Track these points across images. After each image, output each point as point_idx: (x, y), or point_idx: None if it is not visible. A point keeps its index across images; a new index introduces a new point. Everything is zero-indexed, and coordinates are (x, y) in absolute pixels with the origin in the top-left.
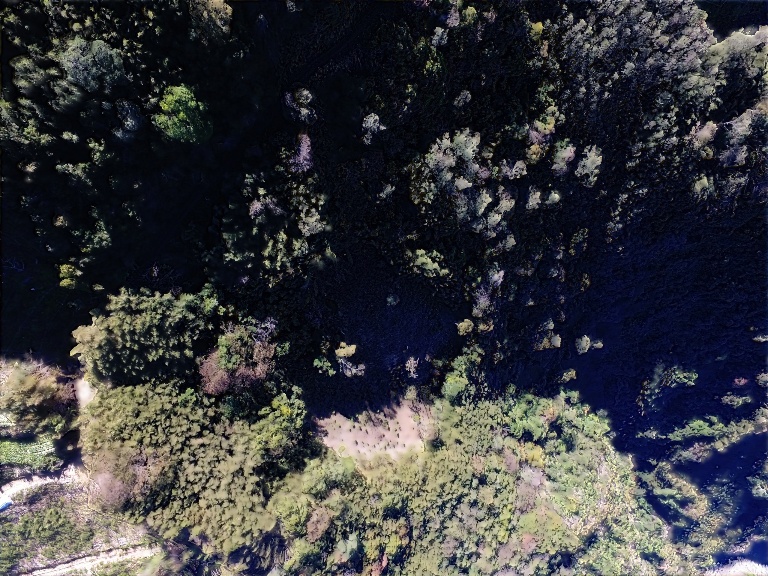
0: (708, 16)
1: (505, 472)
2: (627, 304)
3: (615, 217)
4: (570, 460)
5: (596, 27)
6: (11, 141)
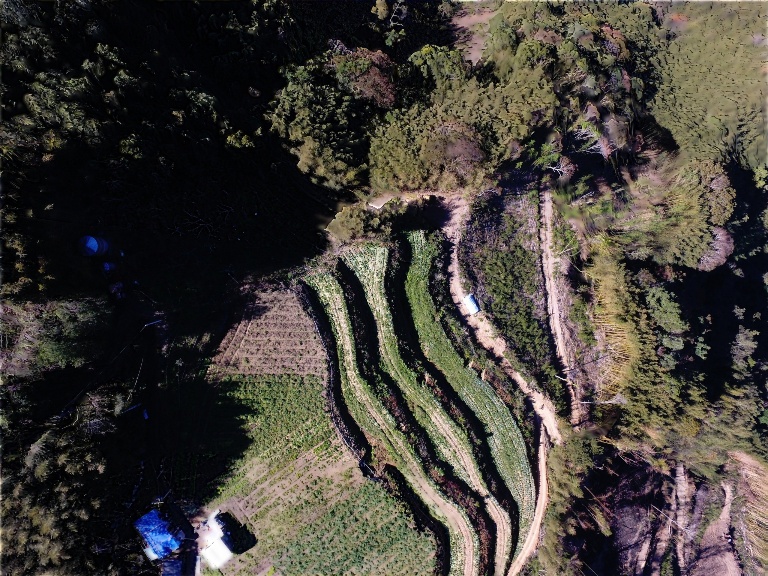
0: None
1: None
2: None
3: None
4: None
5: None
6: (78, 93)
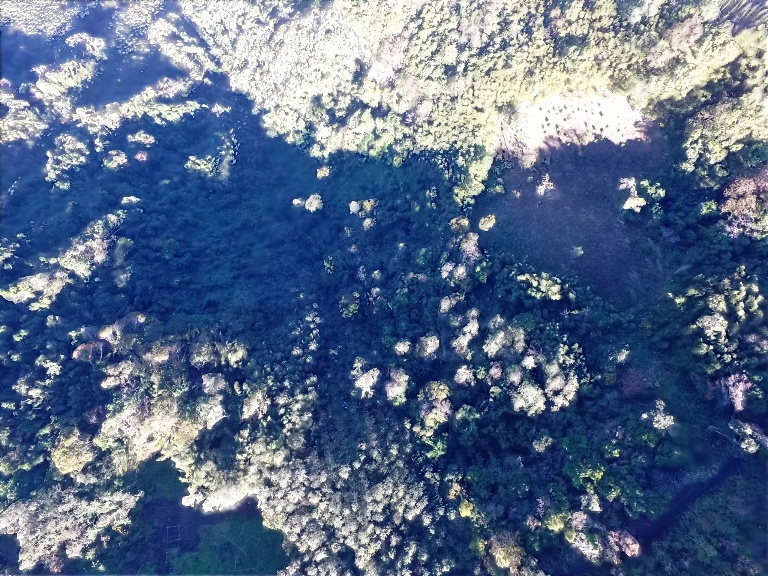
0: (251, 523)
1: (419, 77)
2: (267, 242)
3: (315, 328)
4: (321, 87)
5: (387, 513)
6: None
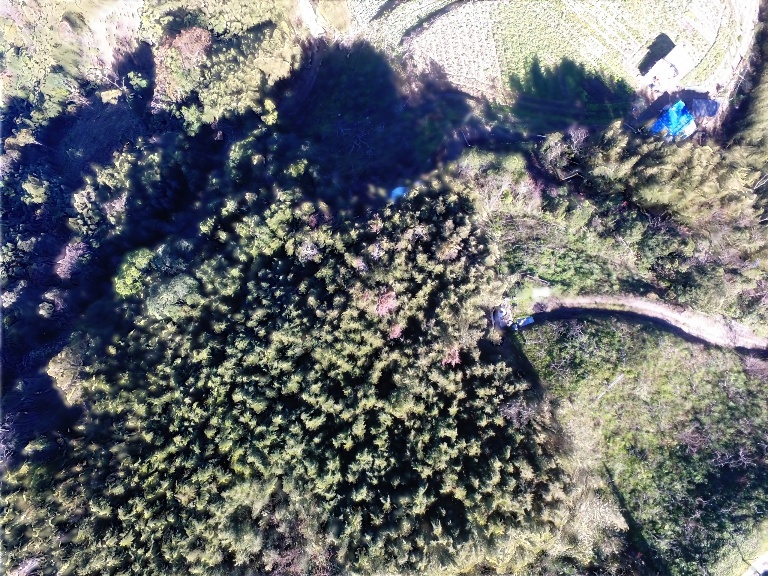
0: None
1: None
2: None
3: None
4: None
5: None
6: None
